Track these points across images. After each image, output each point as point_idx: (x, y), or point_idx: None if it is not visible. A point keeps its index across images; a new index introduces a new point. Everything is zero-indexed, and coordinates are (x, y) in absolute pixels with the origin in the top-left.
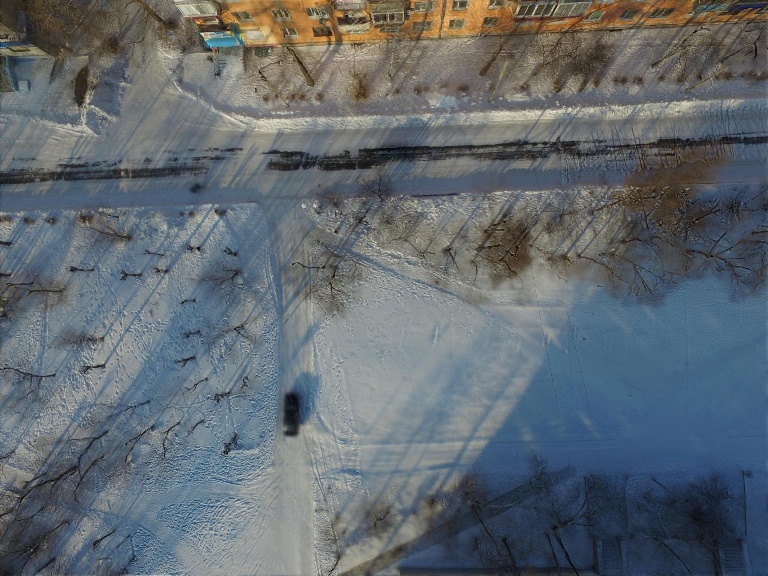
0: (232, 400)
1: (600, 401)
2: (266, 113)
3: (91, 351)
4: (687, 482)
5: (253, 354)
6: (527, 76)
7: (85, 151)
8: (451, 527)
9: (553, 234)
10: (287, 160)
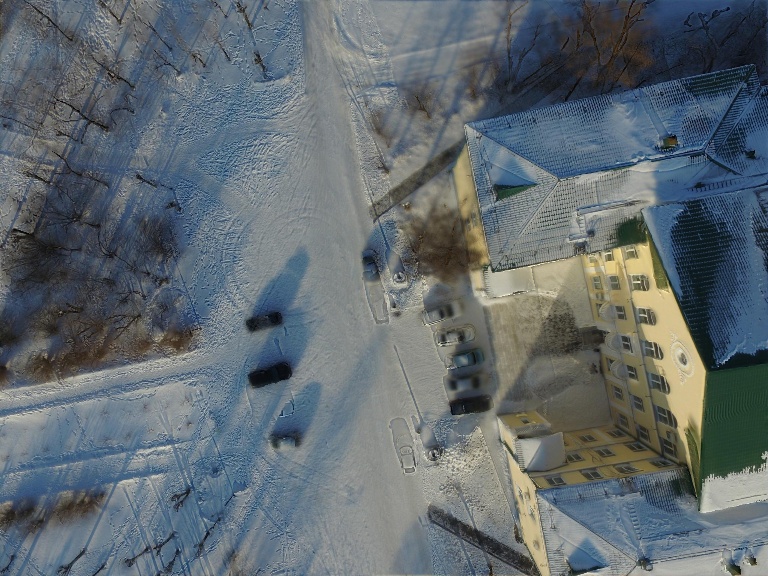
0: (255, 33)
1: None
2: None
3: (105, 9)
4: (724, 28)
5: None
6: None
7: None
8: None
9: None
10: None
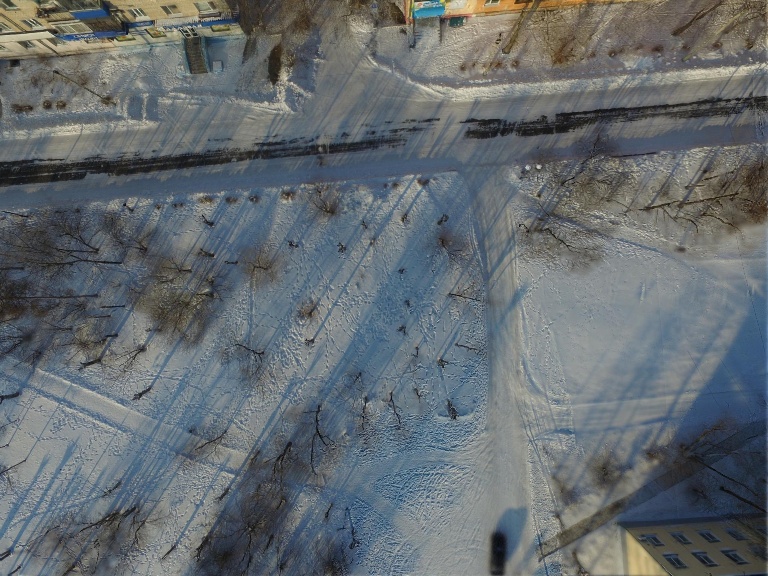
0: None
1: None
2: (464, 82)
3: (299, 327)
4: None
5: (462, 321)
6: (718, 35)
7: (282, 129)
8: (666, 479)
9: (753, 187)
10: (485, 128)
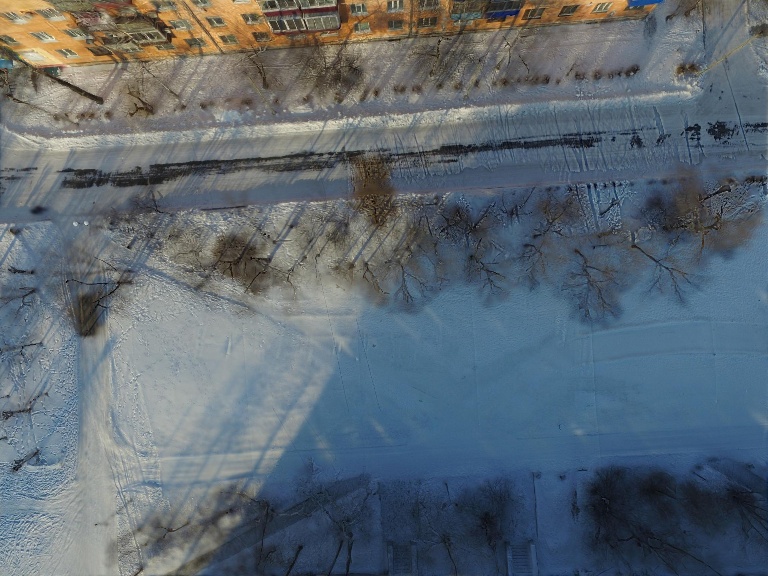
0: (33, 416)
1: (391, 407)
2: (57, 132)
3: None
4: (477, 485)
5: (52, 370)
6: (310, 88)
7: None
8: (251, 536)
9: (339, 243)
10: (81, 178)
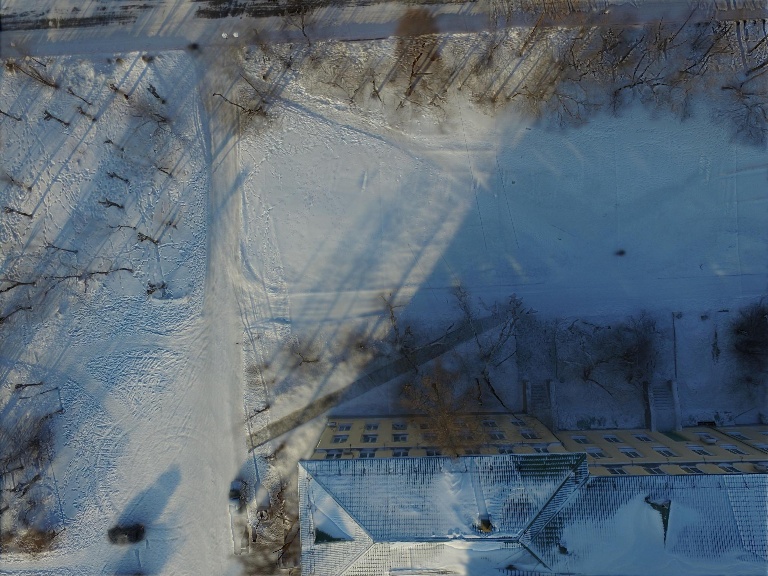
0: (160, 249)
1: (529, 244)
2: None
3: (18, 201)
4: (616, 323)
5: (181, 202)
6: None
7: (13, 1)
8: (381, 375)
9: (481, 76)
10: (215, 8)
